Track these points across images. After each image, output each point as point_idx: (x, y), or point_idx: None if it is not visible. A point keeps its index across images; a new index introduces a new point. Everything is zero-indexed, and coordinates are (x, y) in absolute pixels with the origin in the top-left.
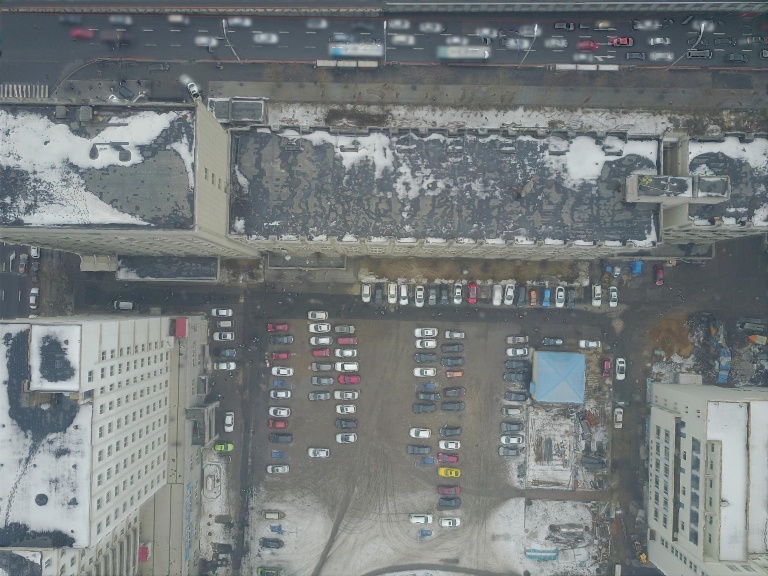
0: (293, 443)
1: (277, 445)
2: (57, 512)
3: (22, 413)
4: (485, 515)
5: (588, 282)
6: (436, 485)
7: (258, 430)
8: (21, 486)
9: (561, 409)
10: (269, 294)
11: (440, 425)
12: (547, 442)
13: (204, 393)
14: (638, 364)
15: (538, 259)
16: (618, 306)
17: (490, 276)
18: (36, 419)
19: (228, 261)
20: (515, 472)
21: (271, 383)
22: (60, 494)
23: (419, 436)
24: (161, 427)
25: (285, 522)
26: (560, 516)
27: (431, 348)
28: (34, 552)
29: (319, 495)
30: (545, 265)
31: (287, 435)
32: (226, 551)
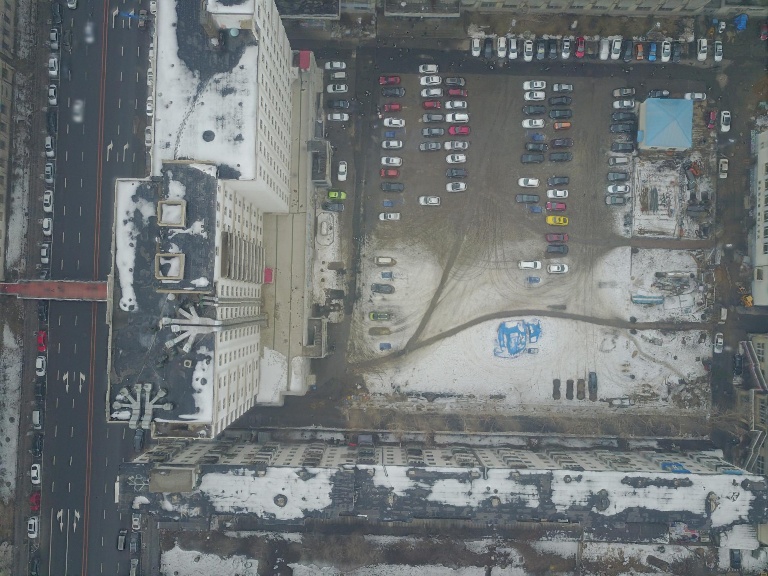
0: (404, 193)
1: (388, 195)
2: (224, 147)
3: (190, 54)
4: (592, 263)
5: (693, 38)
6: (544, 234)
7: (370, 180)
8: (189, 123)
9: (666, 161)
10: (380, 50)
11: (548, 176)
12: (653, 192)
13: (321, 136)
14: (742, 117)
15: (644, 16)
16: (723, 61)
17: (597, 32)
18: (203, 60)
19: (341, 17)
20: (621, 221)
21: (383, 135)
22: (227, 131)
23: (528, 184)
24: (287, 151)
25: (396, 269)
26: (666, 264)
27: (539, 101)
28: (210, 166)
29: (429, 243)
30: (651, 21)
31: (399, 183)
32: (339, 297)
